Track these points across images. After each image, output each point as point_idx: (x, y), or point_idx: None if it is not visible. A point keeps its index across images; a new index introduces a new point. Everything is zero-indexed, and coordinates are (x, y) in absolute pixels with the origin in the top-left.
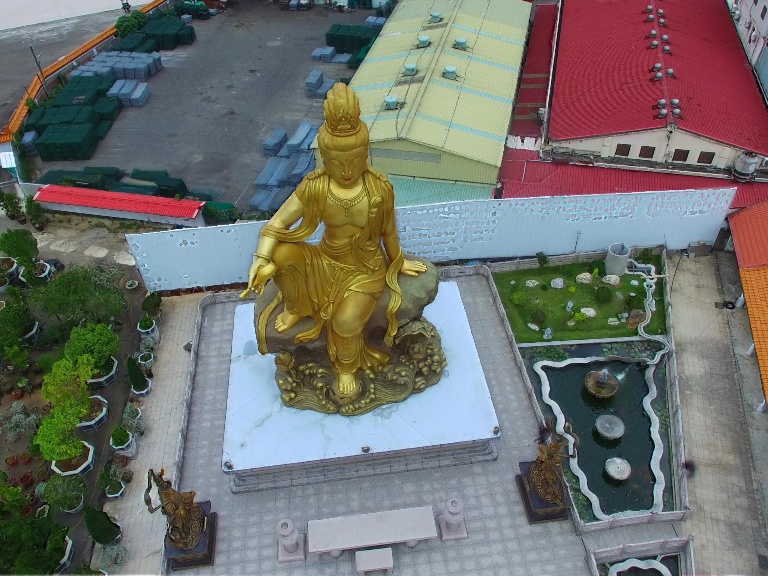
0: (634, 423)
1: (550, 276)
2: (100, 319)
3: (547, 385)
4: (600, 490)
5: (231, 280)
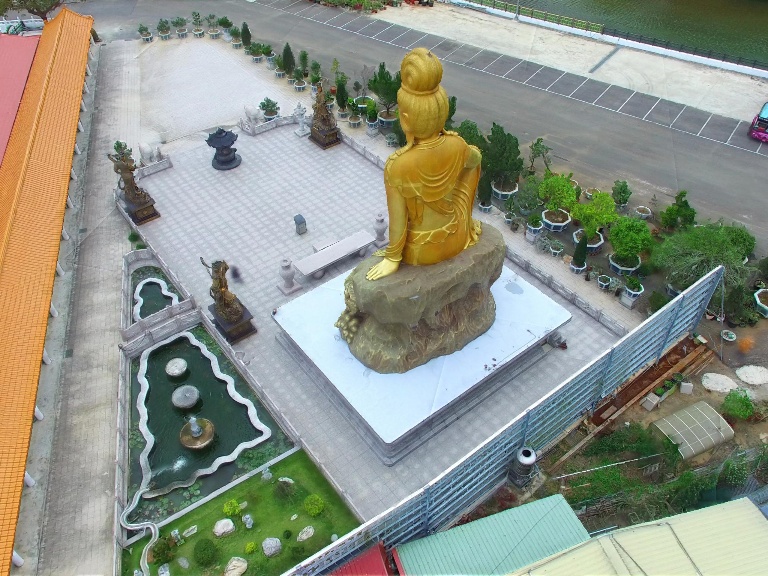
0: (164, 419)
1: (287, 561)
2: (686, 284)
3: (253, 416)
4: (191, 353)
5: (637, 367)
